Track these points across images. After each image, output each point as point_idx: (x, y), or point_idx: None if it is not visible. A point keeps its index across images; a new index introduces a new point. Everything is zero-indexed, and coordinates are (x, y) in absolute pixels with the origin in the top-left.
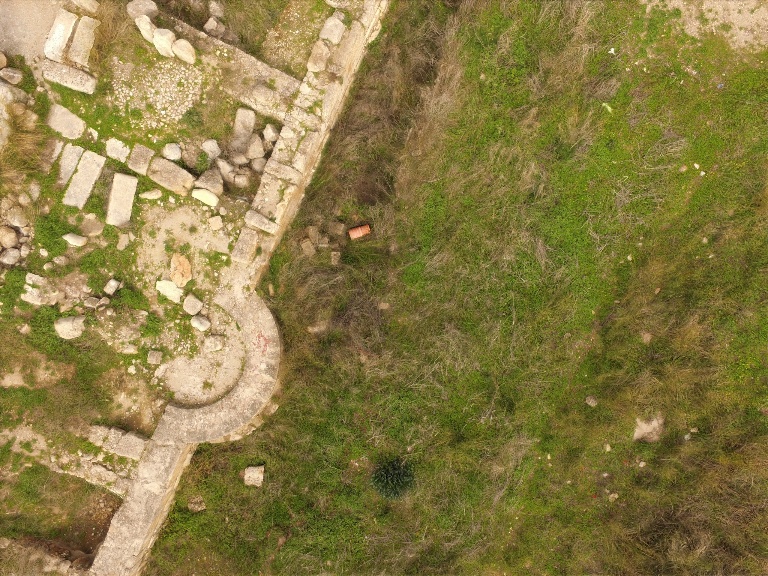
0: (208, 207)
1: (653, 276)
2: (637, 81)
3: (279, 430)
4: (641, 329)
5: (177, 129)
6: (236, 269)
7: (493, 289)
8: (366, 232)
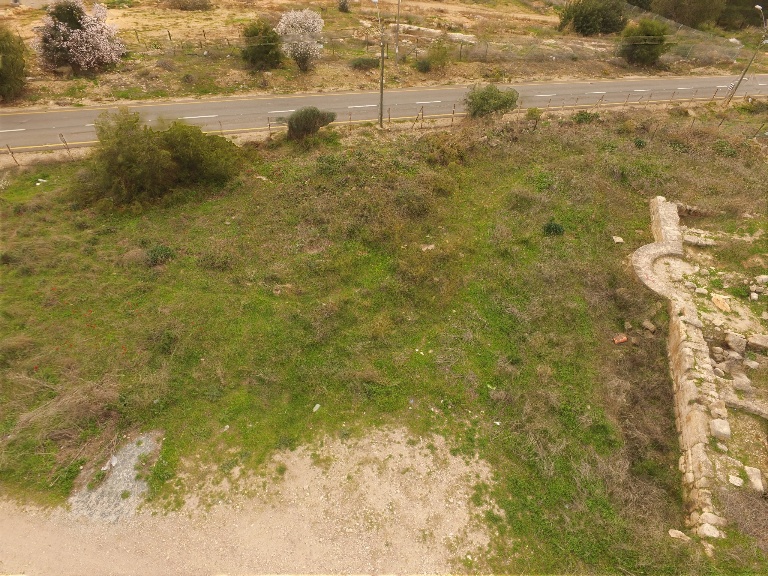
0: None
1: None
2: (474, 403)
3: None
4: None
5: None
6: None
7: None
8: None
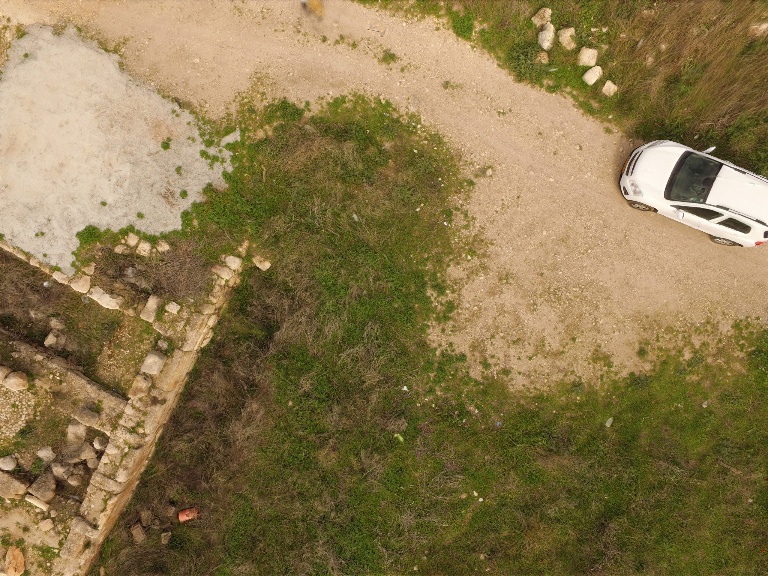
0: (41, 509)
1: None
2: (426, 416)
3: None
4: None
5: (12, 442)
6: (67, 559)
7: None
8: None
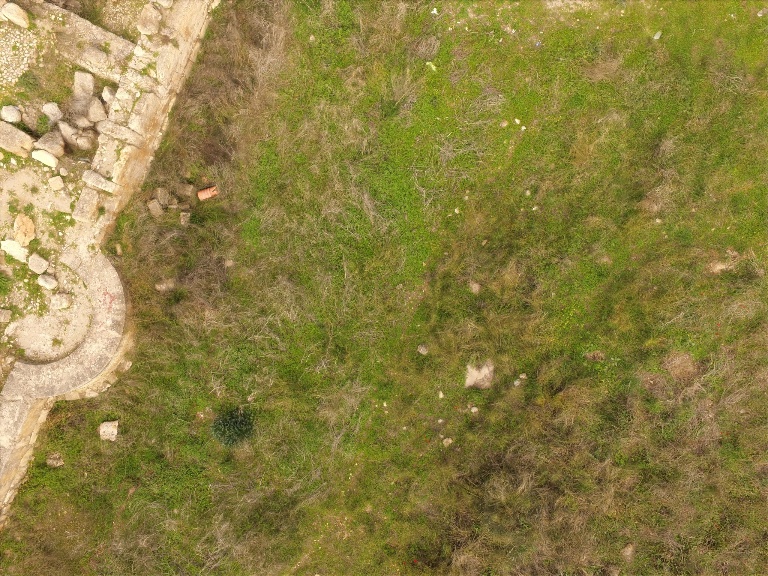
0: (49, 168)
1: (479, 228)
2: (459, 40)
3: (131, 386)
4: (468, 279)
5: (15, 92)
6: (81, 229)
7: (326, 243)
8: (214, 193)
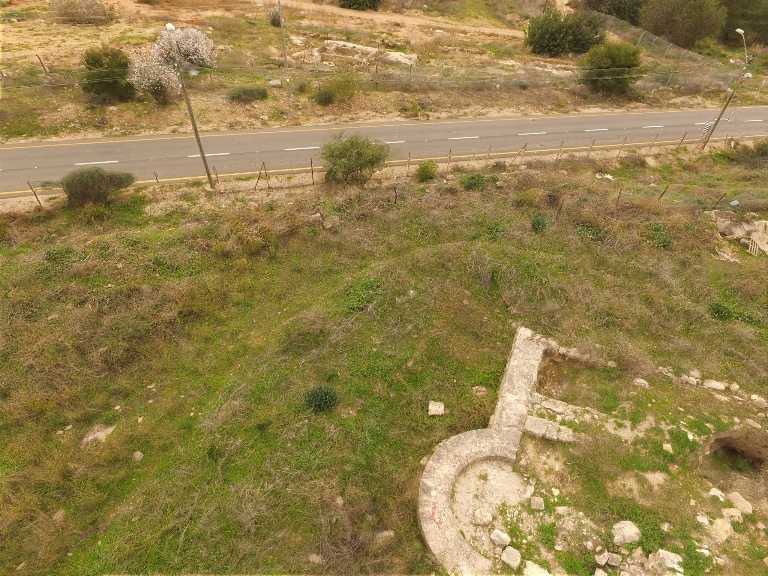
0: None
1: None
2: None
3: (418, 442)
4: None
5: None
6: None
7: (195, 570)
8: None
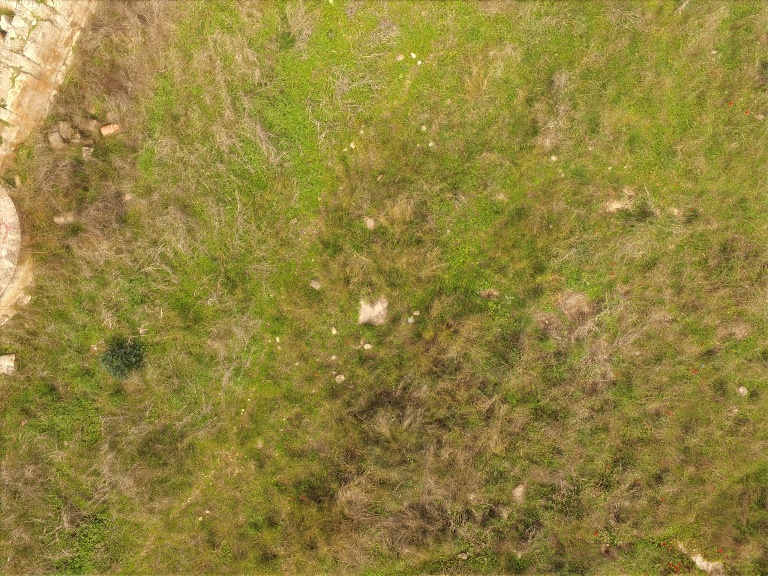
0: None
1: (374, 163)
2: None
3: (29, 319)
4: (362, 214)
5: None
6: None
7: (220, 175)
8: (117, 128)
